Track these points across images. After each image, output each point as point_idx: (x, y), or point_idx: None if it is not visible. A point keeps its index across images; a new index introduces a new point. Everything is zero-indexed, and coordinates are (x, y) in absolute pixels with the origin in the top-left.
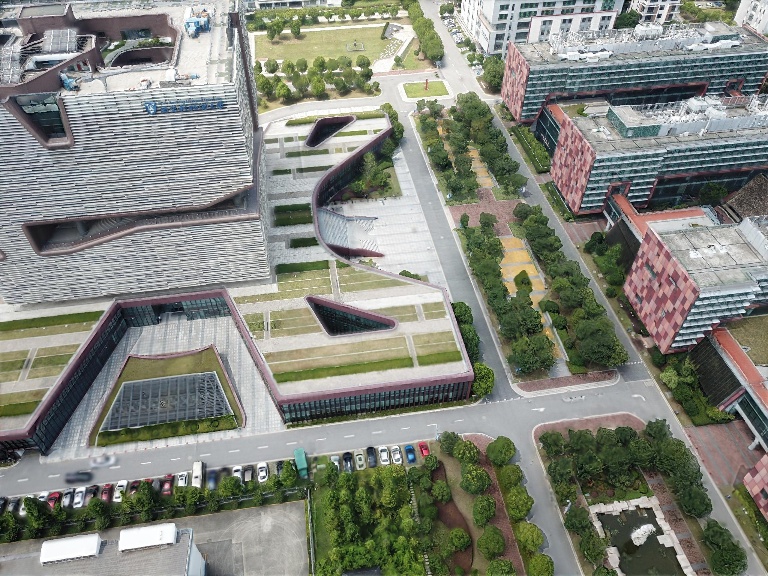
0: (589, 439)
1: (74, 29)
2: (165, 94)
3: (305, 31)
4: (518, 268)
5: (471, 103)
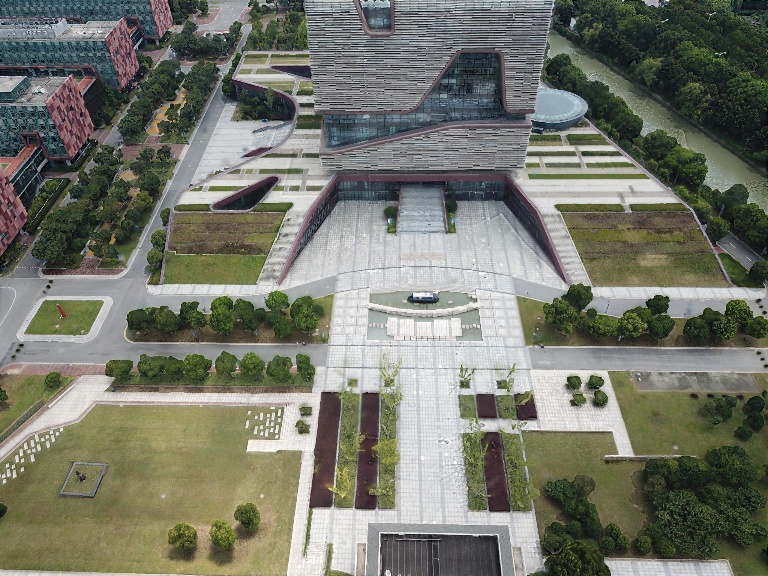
0: (211, 41)
1: None
2: None
3: (157, 575)
4: None
5: (56, 232)
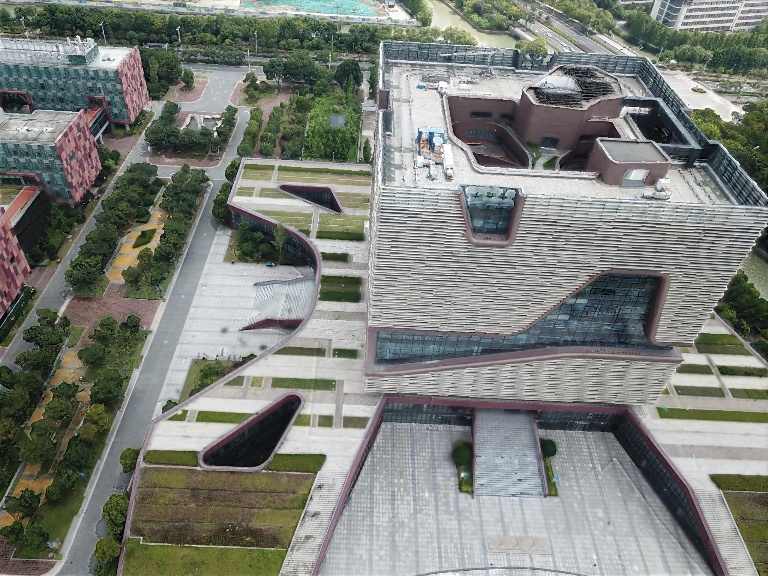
0: (198, 135)
1: (592, 165)
2: (436, 48)
3: None
4: (136, 251)
5: None
